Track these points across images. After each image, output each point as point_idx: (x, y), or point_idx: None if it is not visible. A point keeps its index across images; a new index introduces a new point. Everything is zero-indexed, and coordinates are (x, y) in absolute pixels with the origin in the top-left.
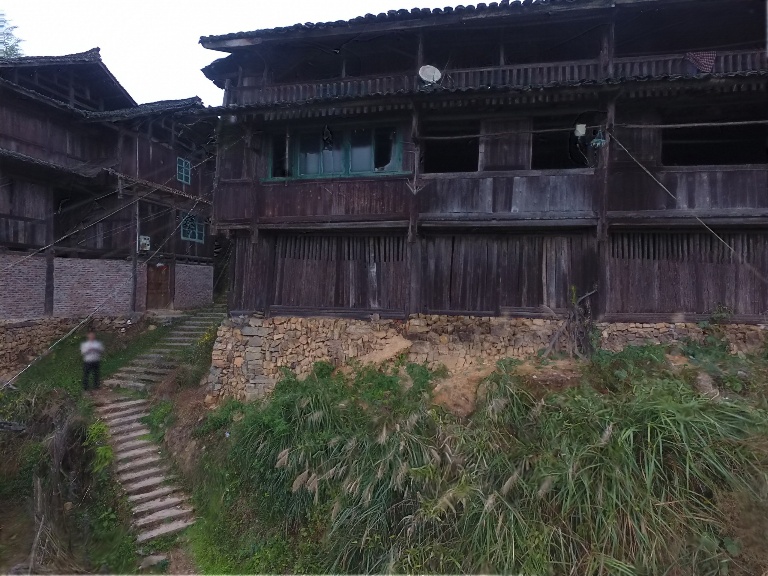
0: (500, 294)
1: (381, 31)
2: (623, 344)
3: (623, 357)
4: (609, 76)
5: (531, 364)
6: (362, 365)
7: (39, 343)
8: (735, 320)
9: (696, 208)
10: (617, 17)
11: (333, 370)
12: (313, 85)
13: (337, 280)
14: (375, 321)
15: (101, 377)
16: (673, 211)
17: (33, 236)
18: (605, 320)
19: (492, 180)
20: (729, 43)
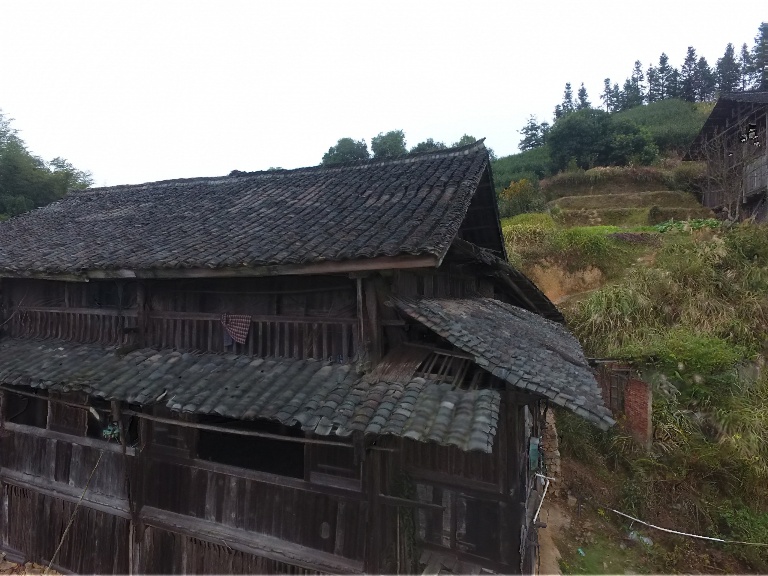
0: (94, 560)
1: None
2: None
3: None
4: None
5: None
6: None
7: None
8: None
9: (223, 523)
10: (117, 282)
11: None
12: None
13: None
14: None
15: None
16: (199, 523)
17: None
18: None
19: (56, 442)
20: (299, 289)
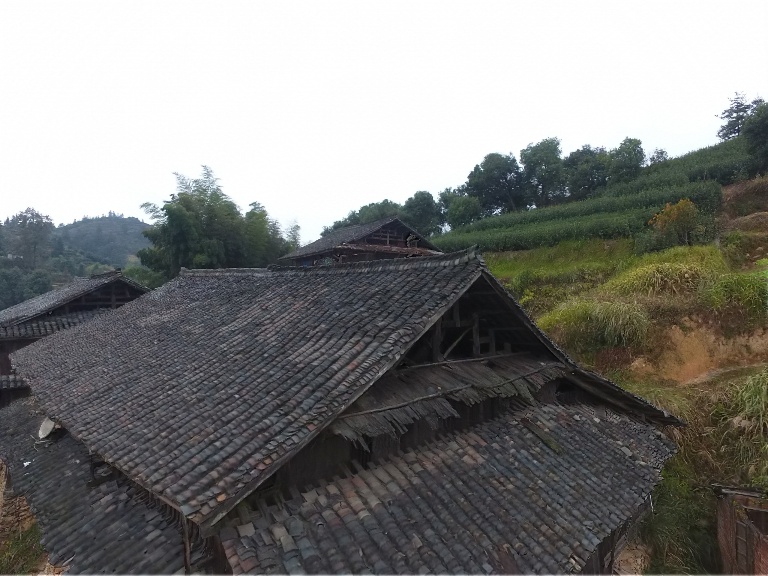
0: None
1: None
2: None
3: None
4: None
5: None
6: None
7: None
8: None
9: None
10: None
11: None
12: None
13: None
14: None
15: None
16: None
17: None
18: None
19: None
20: None
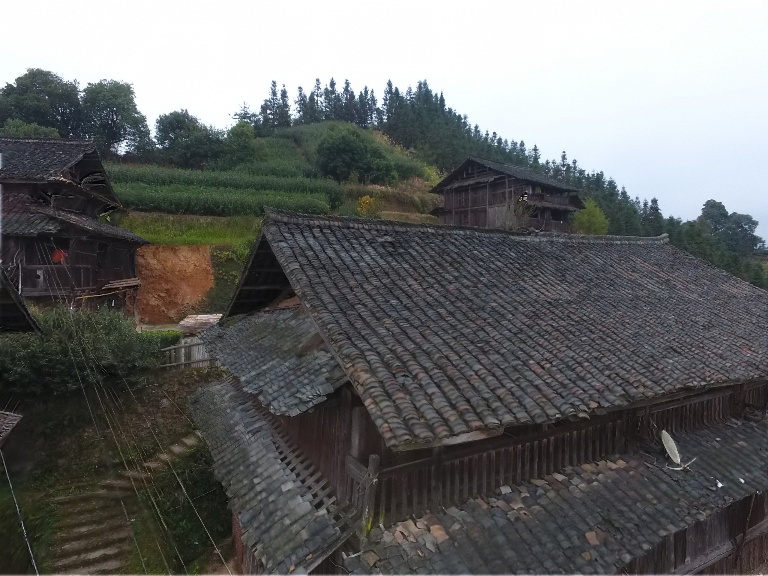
0: None
1: (646, 405)
2: None
3: None
4: (765, 426)
5: None
6: None
7: None
8: None
9: None
10: None
11: None
12: (510, 447)
13: None
14: None
15: None
16: (765, 524)
17: None
18: None
19: None
20: None
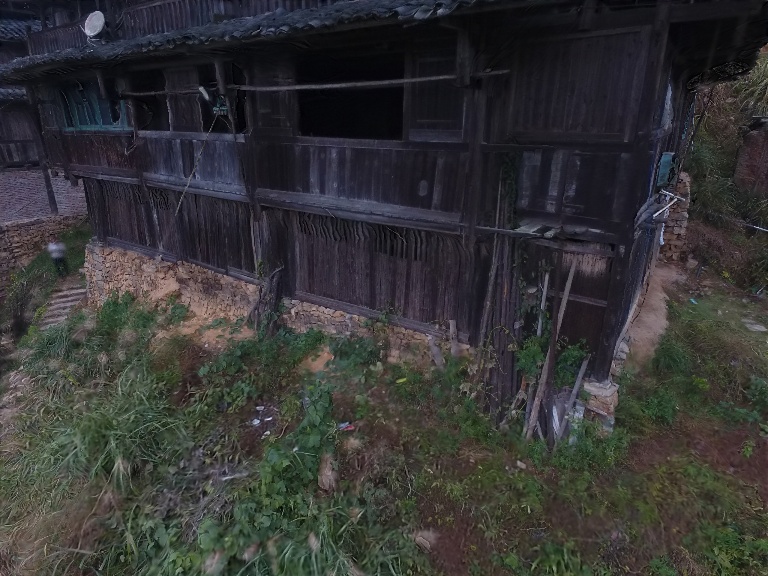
0: (227, 255)
1: None
2: (307, 325)
3: (243, 349)
4: None
5: (222, 330)
6: (147, 300)
7: (49, 236)
8: (403, 324)
9: (326, 195)
10: None
11: (134, 299)
12: (66, 29)
13: (137, 221)
14: (157, 263)
15: (80, 265)
16: (305, 196)
17: (26, 154)
18: (295, 298)
19: (180, 142)
20: None
